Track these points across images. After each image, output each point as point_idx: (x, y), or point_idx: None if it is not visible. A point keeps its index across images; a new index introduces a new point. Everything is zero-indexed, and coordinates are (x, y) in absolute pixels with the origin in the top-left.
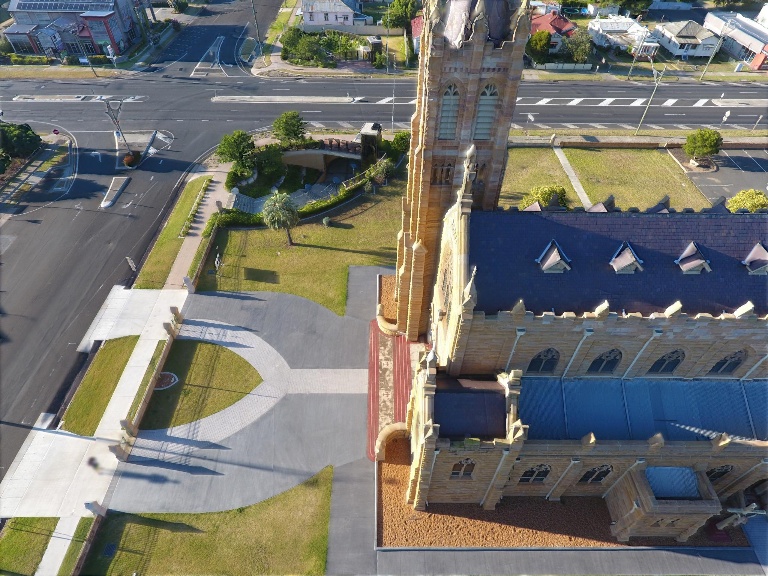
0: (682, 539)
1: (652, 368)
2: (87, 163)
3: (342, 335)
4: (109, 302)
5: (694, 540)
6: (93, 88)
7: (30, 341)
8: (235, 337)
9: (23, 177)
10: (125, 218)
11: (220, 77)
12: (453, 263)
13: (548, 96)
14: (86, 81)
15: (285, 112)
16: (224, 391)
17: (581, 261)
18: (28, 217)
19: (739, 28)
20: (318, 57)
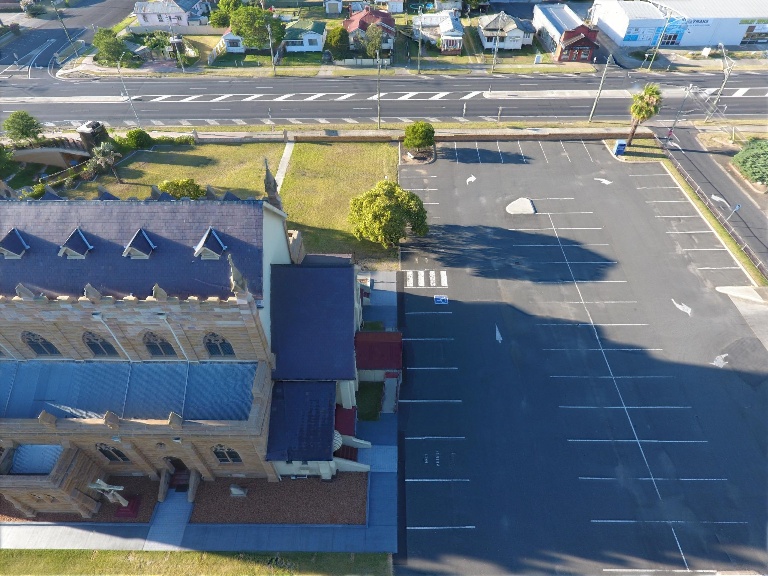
0: (84, 515)
1: (39, 350)
2: None
3: None
4: None
5: (100, 516)
6: None
7: None
8: None
9: None
10: None
11: (21, 79)
12: None
13: (323, 92)
14: None
15: None
16: None
17: None
18: None
19: (553, 20)
20: (123, 58)
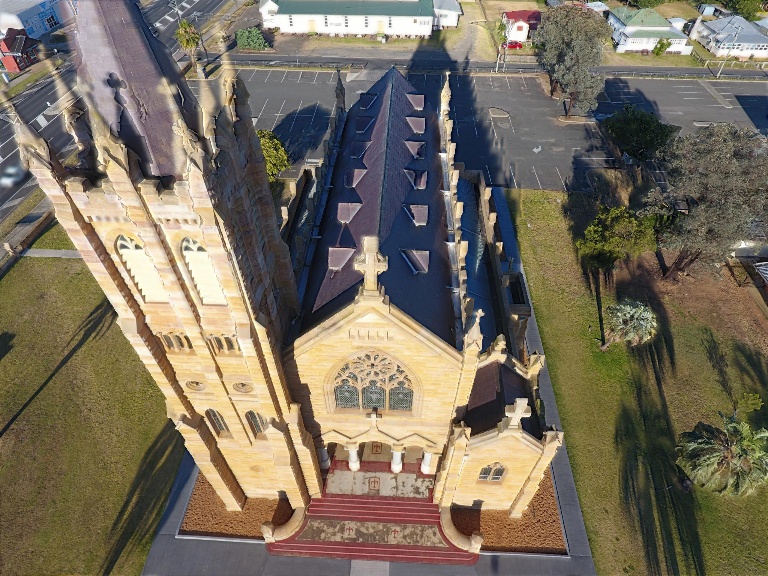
0: None
1: None
2: None
3: None
4: None
5: None
6: None
7: None
8: None
9: None
10: None
11: None
12: (398, 354)
13: None
14: None
15: None
16: None
17: (415, 243)
18: None
19: None
20: None
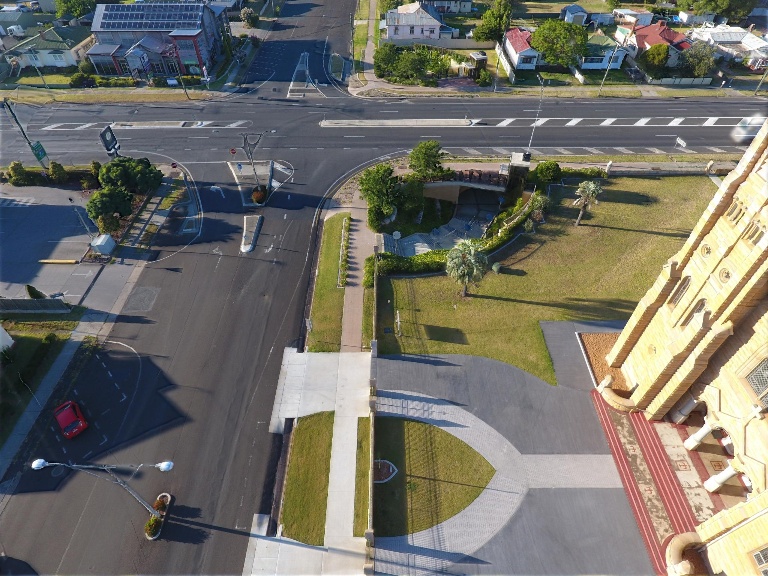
0: None
1: None
2: (210, 199)
3: (564, 410)
4: (286, 369)
5: None
6: (190, 112)
7: (215, 420)
8: (443, 413)
9: (146, 216)
10: (272, 265)
11: (319, 98)
12: None
13: (678, 115)
14: (179, 104)
15: (420, 141)
16: (456, 485)
17: None
18: (166, 264)
19: None
20: (418, 75)
